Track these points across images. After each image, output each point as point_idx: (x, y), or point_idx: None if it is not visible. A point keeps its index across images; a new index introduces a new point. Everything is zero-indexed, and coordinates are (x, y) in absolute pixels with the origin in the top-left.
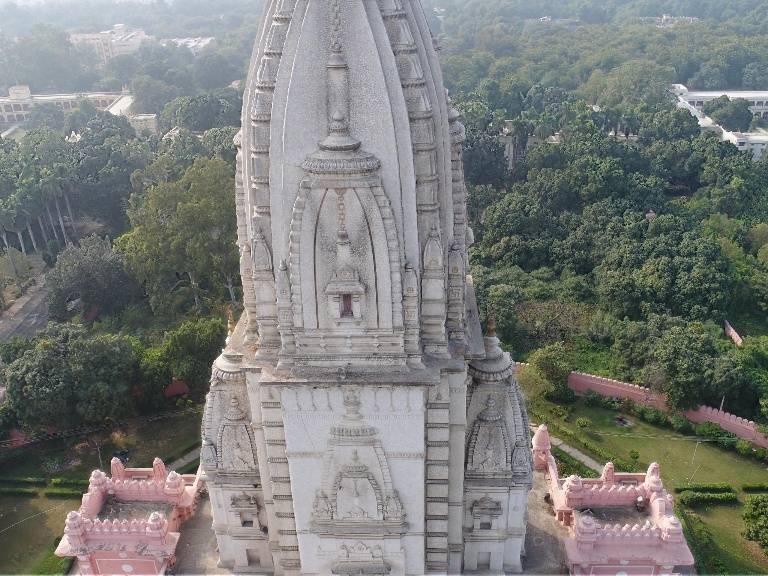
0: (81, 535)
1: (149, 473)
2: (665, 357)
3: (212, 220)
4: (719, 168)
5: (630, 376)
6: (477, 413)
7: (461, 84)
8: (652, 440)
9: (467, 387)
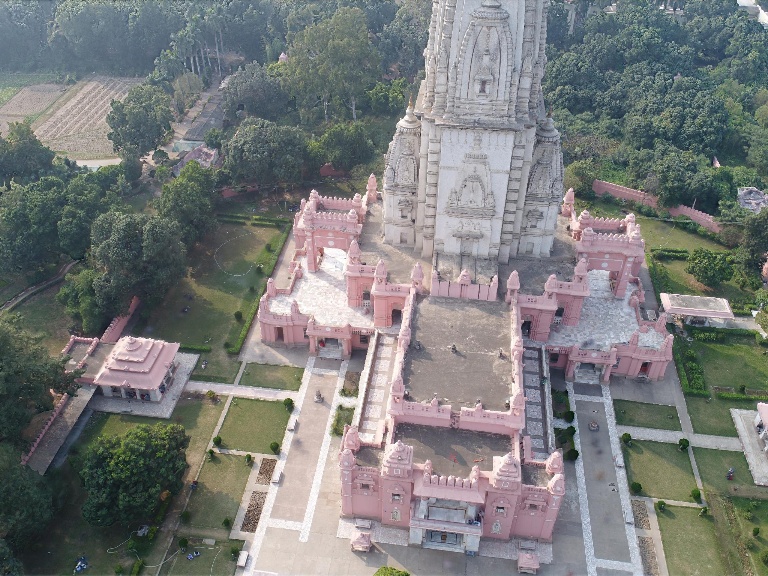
0: (311, 220)
1: None
2: (661, 170)
3: (352, 54)
4: (742, 43)
5: (636, 185)
6: (537, 160)
7: None
8: (643, 224)
9: None
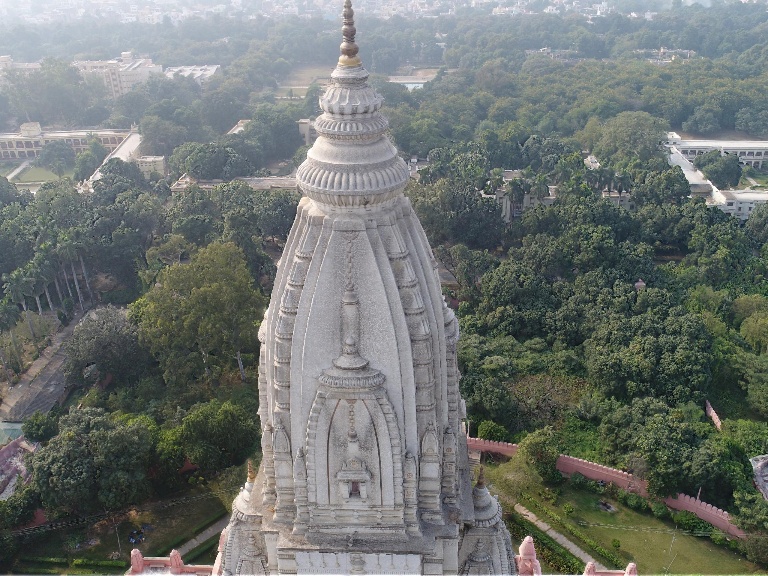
0: None
1: (166, 562)
2: (647, 448)
3: (224, 304)
4: (706, 236)
5: (615, 460)
6: (468, 554)
7: (461, 129)
8: None
9: (459, 531)
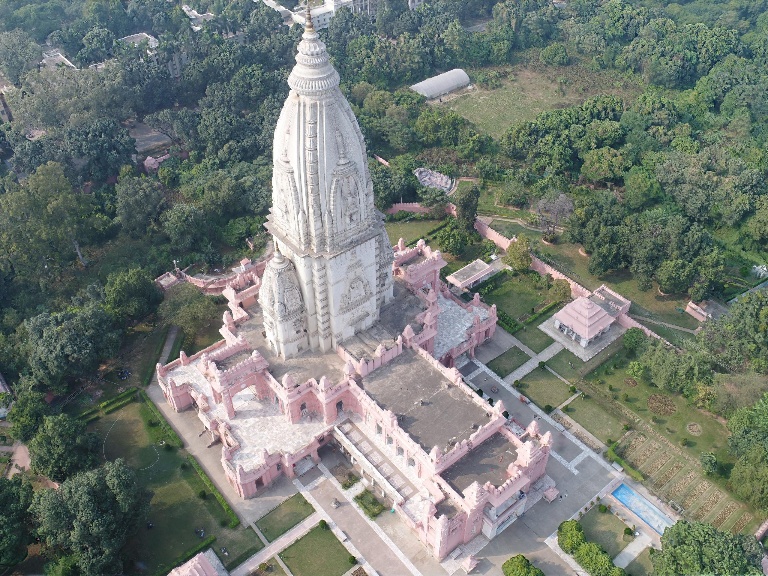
0: None
1: (177, 363)
2: None
3: (75, 208)
4: None
5: None
6: None
7: (52, 5)
8: None
9: None
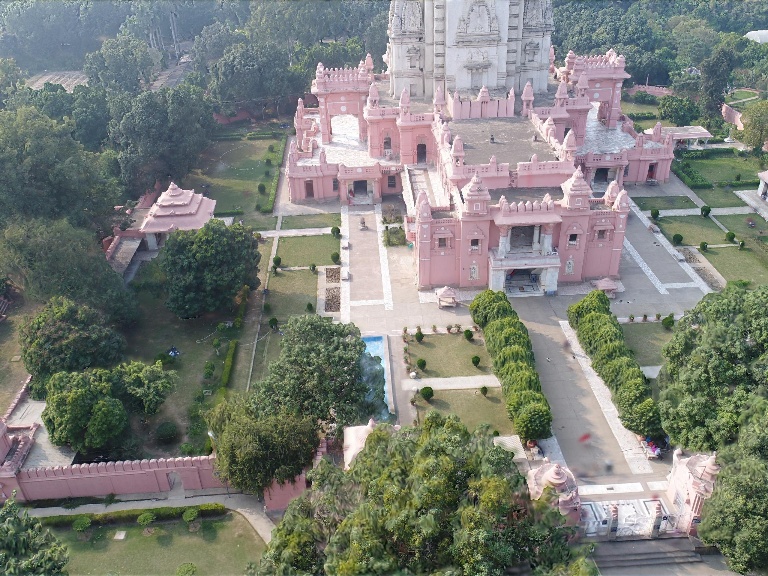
0: (324, 84)
1: None
2: None
3: None
4: None
5: None
6: None
7: None
8: None
9: None
